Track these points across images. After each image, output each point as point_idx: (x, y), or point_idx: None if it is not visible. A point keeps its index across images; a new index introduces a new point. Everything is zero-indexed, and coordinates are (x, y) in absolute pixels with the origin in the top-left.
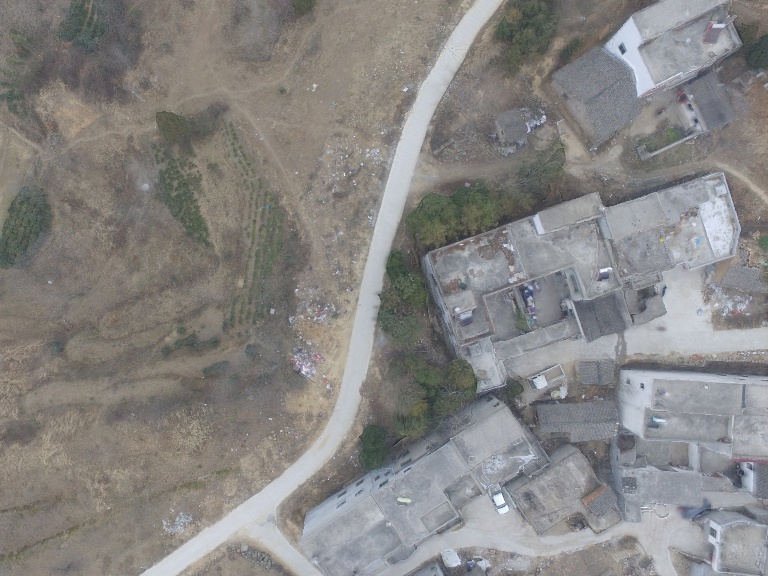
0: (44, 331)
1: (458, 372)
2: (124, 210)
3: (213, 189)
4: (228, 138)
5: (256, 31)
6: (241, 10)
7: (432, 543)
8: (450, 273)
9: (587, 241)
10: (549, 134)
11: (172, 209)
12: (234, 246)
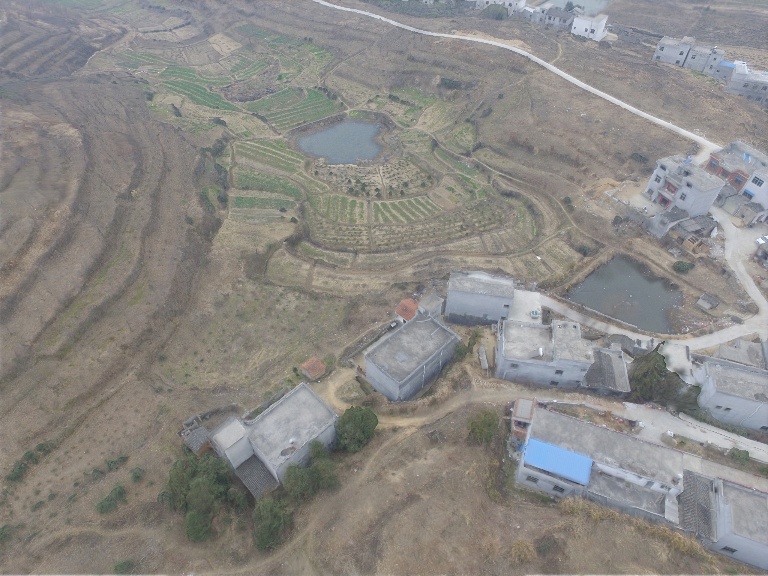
0: None
1: None
2: None
3: None
4: None
5: None
6: None
7: (720, 214)
8: None
9: None
10: None
11: None
12: None
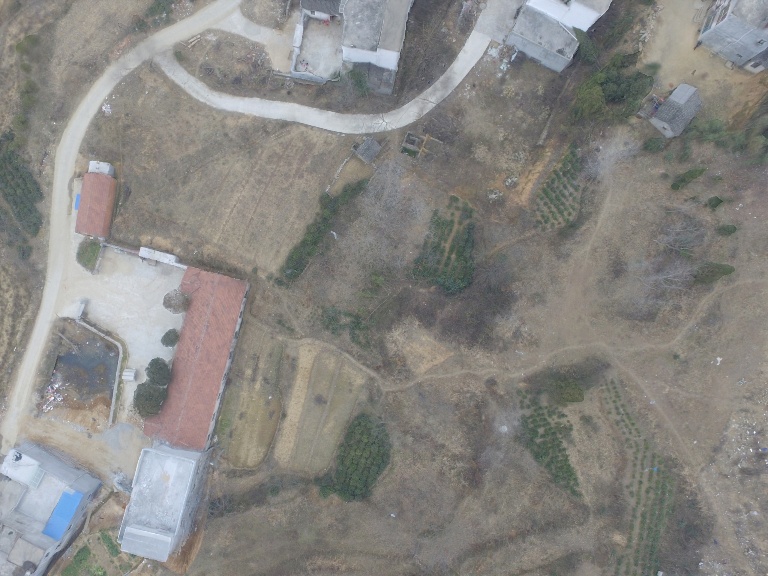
0: (398, 572)
1: None
2: (475, 447)
3: (585, 440)
4: (609, 395)
5: (633, 286)
6: (619, 265)
7: None
8: None
9: None
10: None
11: (537, 455)
12: (608, 499)
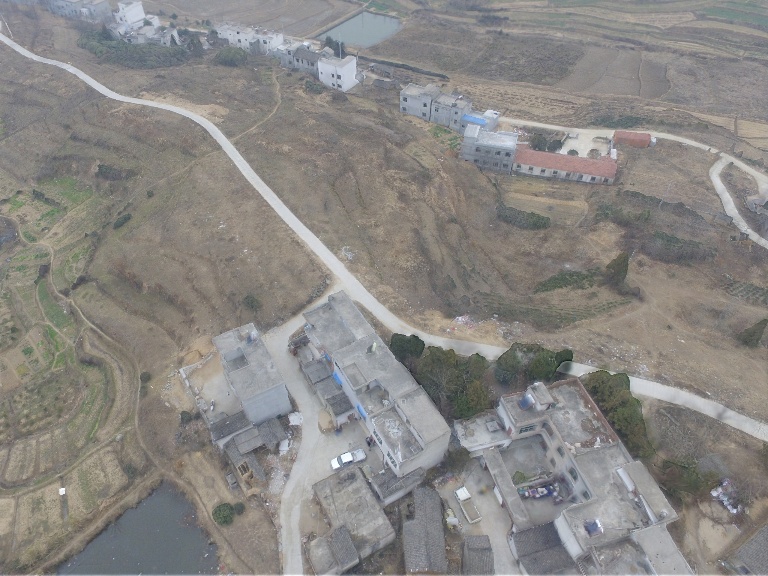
0: (461, 218)
1: (481, 387)
2: None
3: (578, 294)
4: (619, 300)
5: (709, 322)
6: (721, 313)
7: (310, 406)
8: (562, 396)
9: (623, 518)
10: (719, 513)
11: None
12: None
